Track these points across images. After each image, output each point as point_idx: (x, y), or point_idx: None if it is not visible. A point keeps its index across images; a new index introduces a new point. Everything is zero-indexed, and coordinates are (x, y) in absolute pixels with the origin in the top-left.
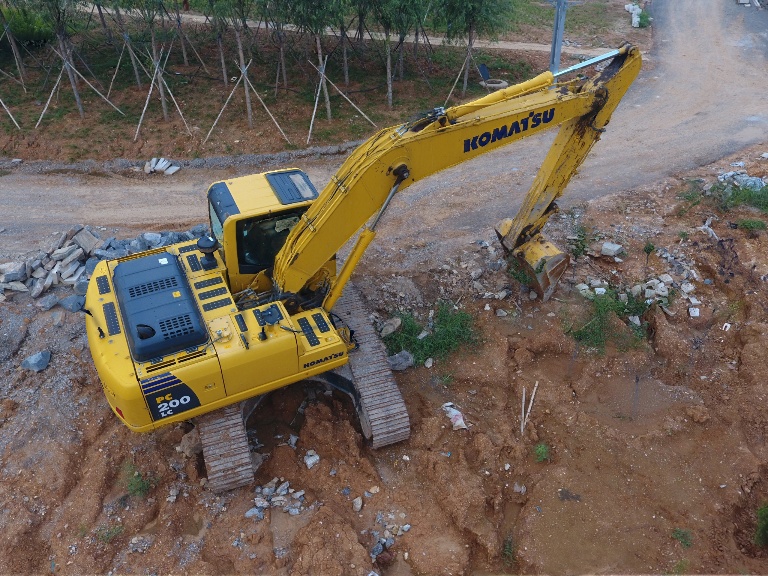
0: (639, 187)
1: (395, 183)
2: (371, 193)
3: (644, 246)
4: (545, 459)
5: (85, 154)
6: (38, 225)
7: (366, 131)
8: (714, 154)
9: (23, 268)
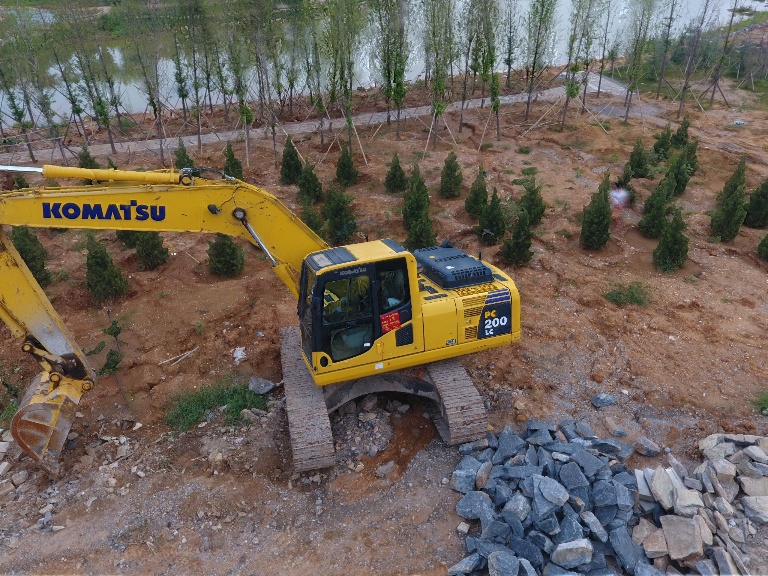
0: None
1: None
2: None
3: None
4: None
5: None
6: None
7: None
8: None
9: None
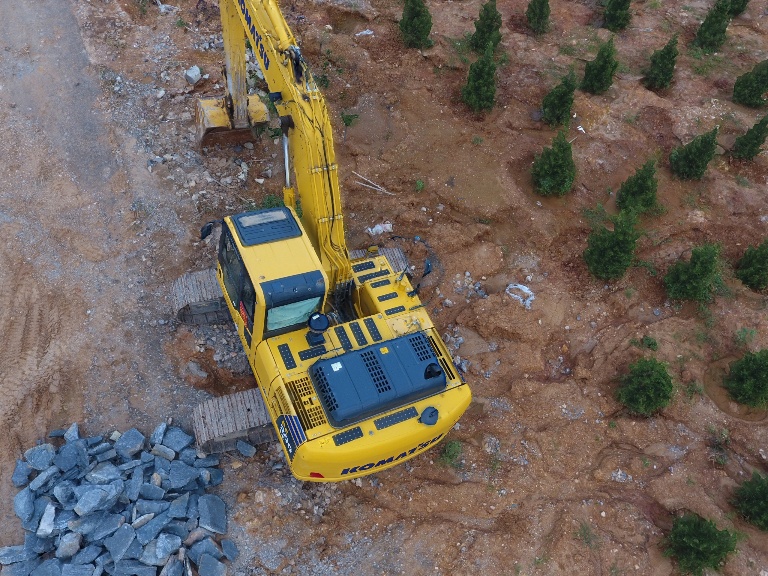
0: (79, 17)
1: None
2: None
3: (188, 53)
4: None
5: None
6: None
7: None
8: None
9: None
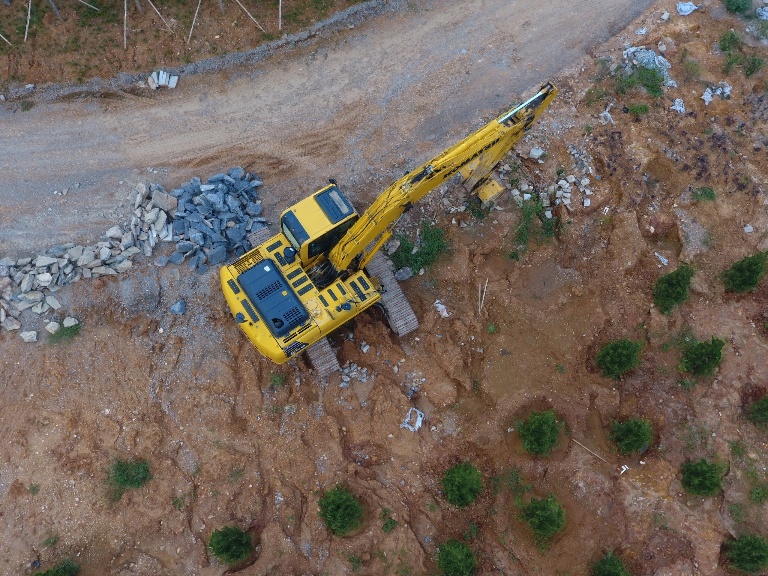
0: (561, 72)
1: (404, 211)
2: (389, 217)
3: (560, 143)
4: (493, 331)
5: (87, 71)
6: (102, 174)
7: (329, 5)
8: (625, 17)
9: (133, 237)
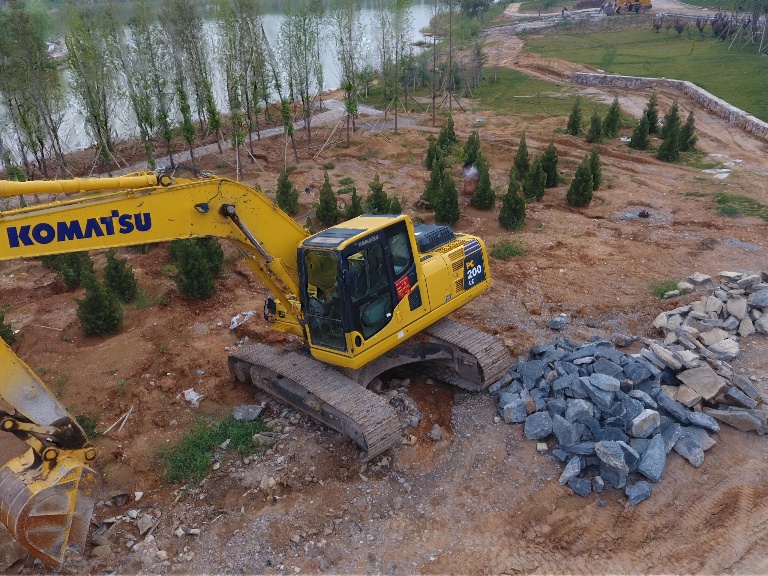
0: None
1: None
2: None
3: None
4: None
5: None
6: None
7: None
8: None
9: None
